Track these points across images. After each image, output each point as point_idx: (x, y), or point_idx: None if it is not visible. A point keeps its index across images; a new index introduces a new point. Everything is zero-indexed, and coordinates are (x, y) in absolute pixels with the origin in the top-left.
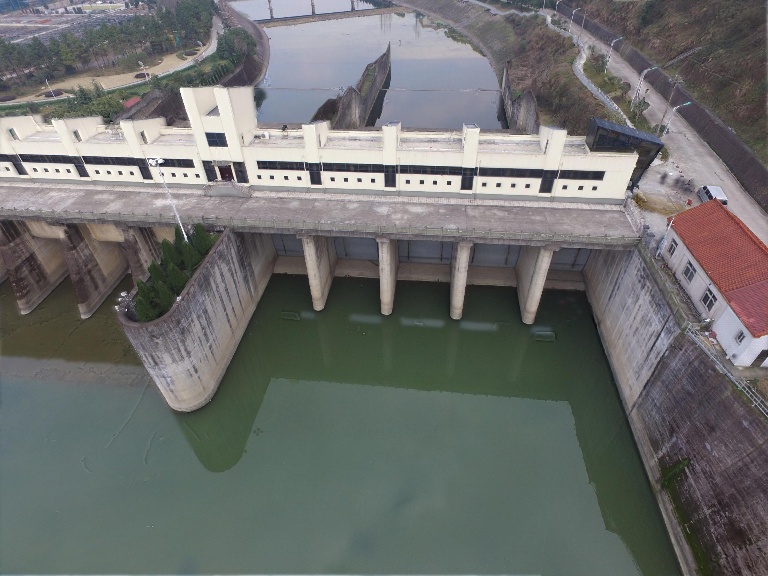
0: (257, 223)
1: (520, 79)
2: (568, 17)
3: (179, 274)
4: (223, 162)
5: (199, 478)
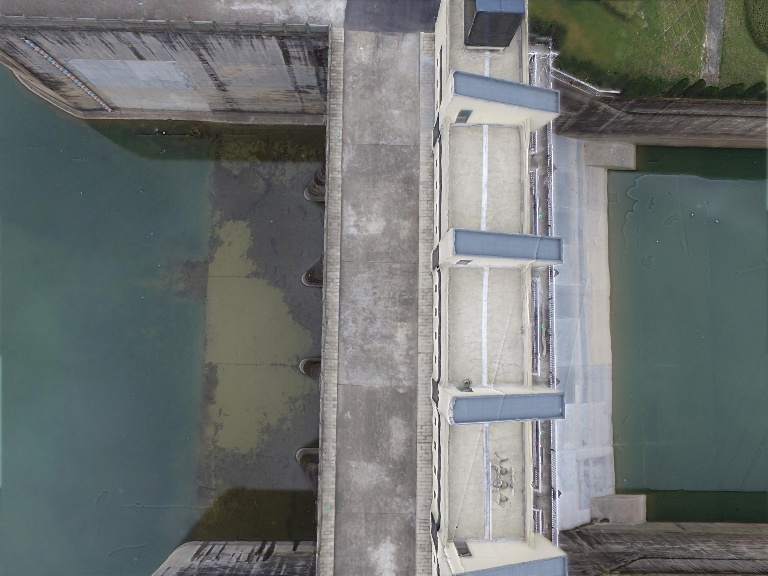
0: None
1: None
2: None
3: None
4: None
5: None
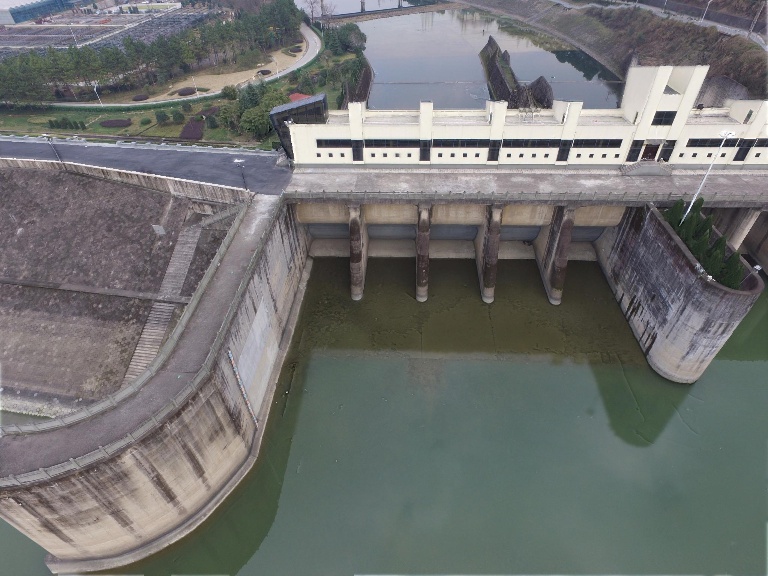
0: (725, 198)
1: None
2: (699, 8)
3: (725, 245)
4: (662, 140)
5: (761, 443)
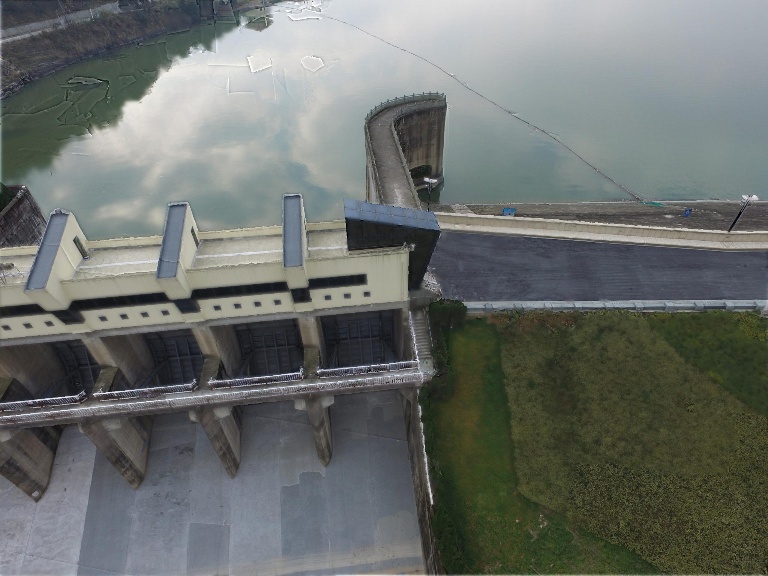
0: None
1: None
2: None
3: None
4: None
5: None
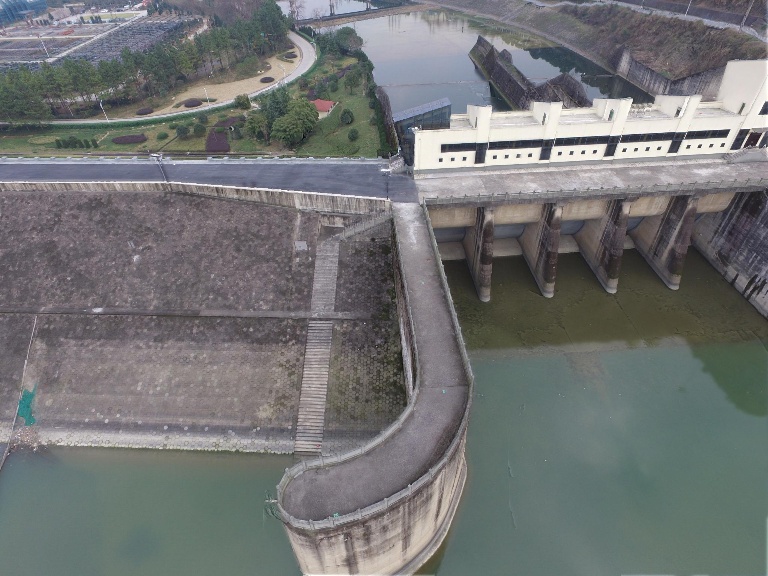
0: None
1: (647, 62)
2: (682, 3)
3: None
4: (767, 128)
5: None
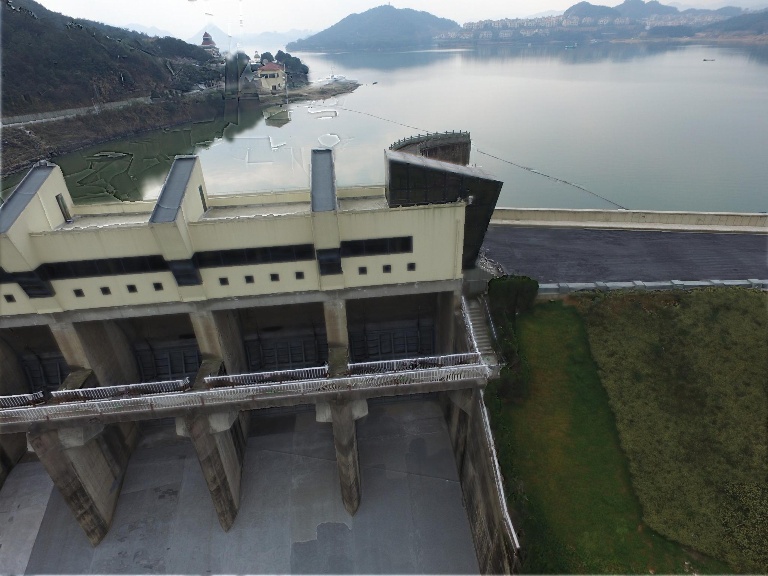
0: None
1: None
2: None
3: None
4: None
5: None
